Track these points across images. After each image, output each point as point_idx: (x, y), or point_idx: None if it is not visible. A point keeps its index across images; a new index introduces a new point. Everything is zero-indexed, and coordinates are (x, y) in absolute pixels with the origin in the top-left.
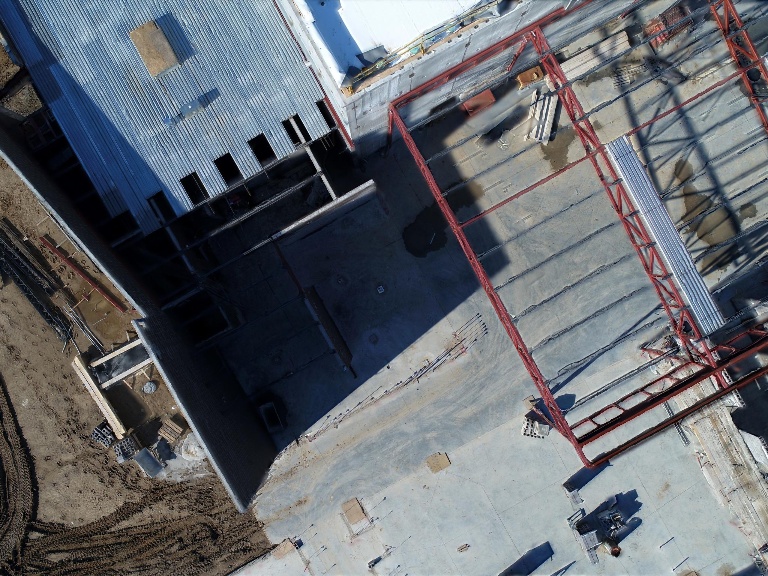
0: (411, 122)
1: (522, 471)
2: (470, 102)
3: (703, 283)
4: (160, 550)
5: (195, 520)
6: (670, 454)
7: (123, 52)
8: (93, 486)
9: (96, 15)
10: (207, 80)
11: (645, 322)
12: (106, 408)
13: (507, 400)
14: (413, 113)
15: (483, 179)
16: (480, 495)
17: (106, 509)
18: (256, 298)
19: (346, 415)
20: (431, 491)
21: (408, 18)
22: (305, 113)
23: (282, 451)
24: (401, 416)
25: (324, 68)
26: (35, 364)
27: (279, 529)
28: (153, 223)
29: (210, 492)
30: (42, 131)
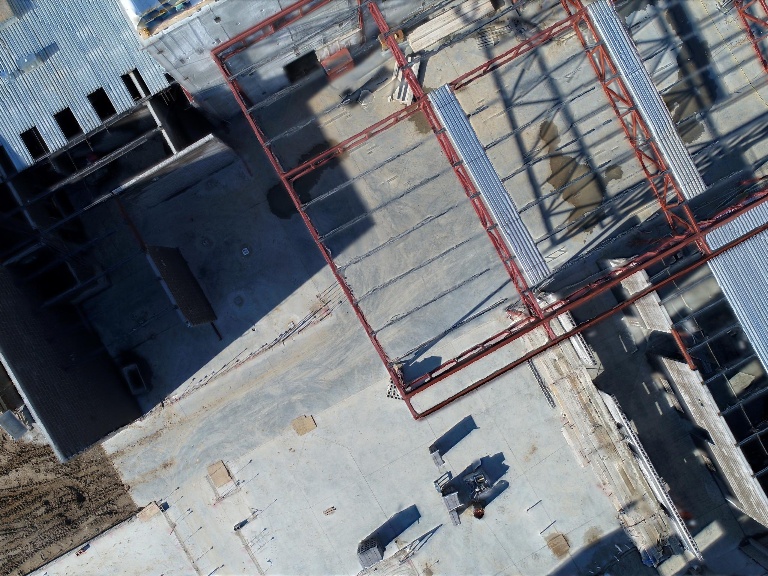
0: (265, 81)
1: (388, 434)
2: (327, 61)
3: (528, 233)
4: (27, 513)
5: (62, 483)
6: (537, 417)
7: None
8: None
9: None
10: (46, 34)
11: (510, 284)
12: None
13: (373, 362)
14: (259, 69)
15: None
16: (346, 458)
17: None
18: (120, 260)
19: (212, 377)
20: (297, 454)
21: None
22: (144, 67)
23: (147, 413)
24: (267, 378)
25: None
26: None
27: (145, 492)
28: None
29: None
30: None
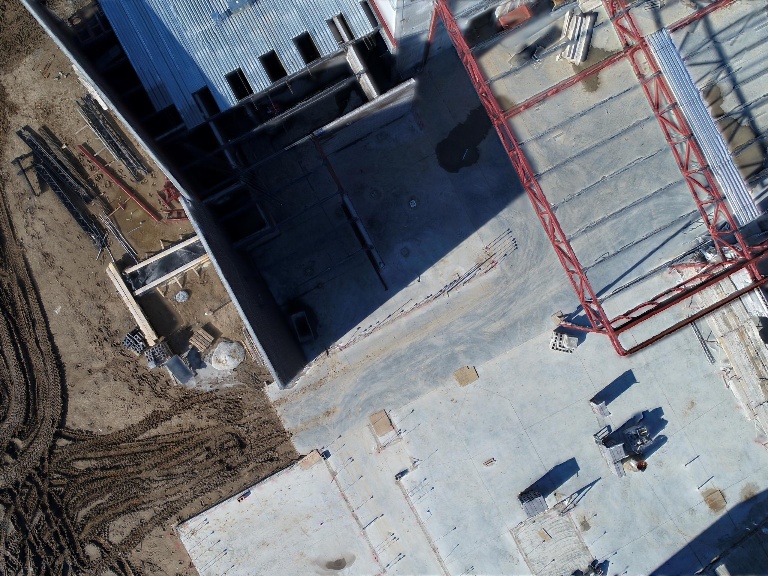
0: None
1: (549, 386)
2: (505, 18)
3: (738, 175)
4: (188, 459)
5: (223, 430)
6: (696, 372)
7: None
8: (123, 394)
9: None
10: None
11: (673, 241)
12: (139, 314)
13: (536, 315)
14: None
15: (515, 97)
16: (507, 409)
17: (135, 417)
18: (290, 209)
19: (376, 327)
20: (459, 405)
21: None
22: (349, 12)
23: (312, 361)
24: (431, 329)
25: None
26: (69, 271)
27: (307, 440)
28: (197, 117)
29: (239, 402)
30: (91, 26)
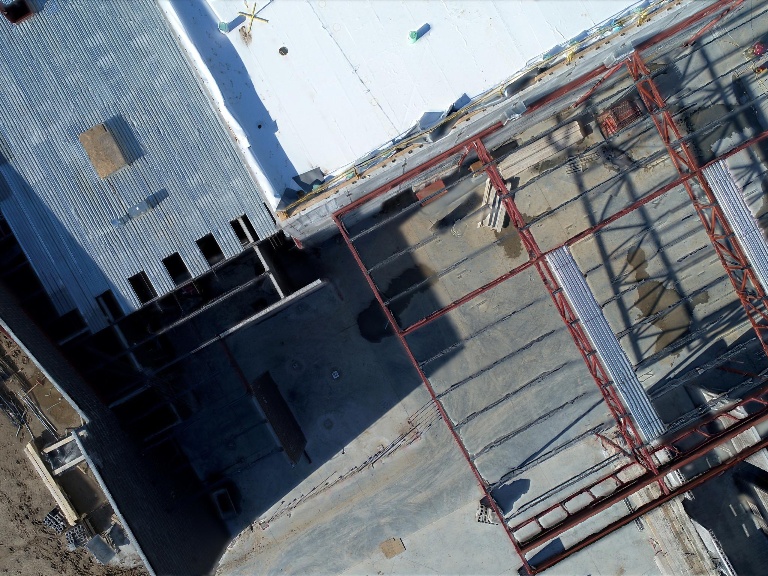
0: (363, 214)
1: (477, 557)
2: (422, 193)
3: (643, 391)
4: None
5: None
6: (625, 539)
7: (72, 152)
8: (45, 572)
9: (46, 116)
10: (156, 180)
11: (599, 407)
12: (59, 495)
13: (462, 485)
14: (362, 210)
15: (437, 265)
16: None
17: None
18: (211, 383)
19: (301, 500)
20: None
21: (344, 141)
22: (253, 213)
23: (236, 537)
24: (356, 501)
25: None
26: None
27: None
28: (101, 321)
29: None
30: None
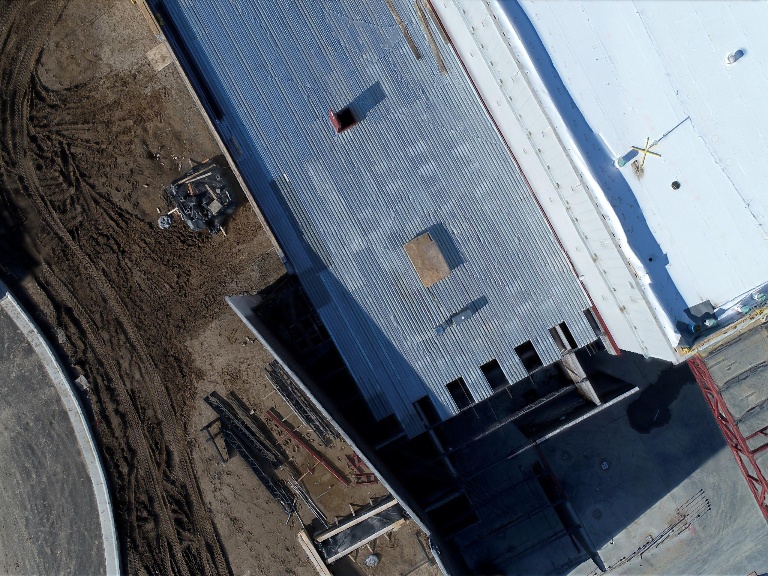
0: None
1: None
2: None
3: None
4: None
5: None
6: None
7: (392, 259)
8: None
9: (366, 223)
10: (475, 288)
11: None
12: None
13: None
14: None
15: None
16: None
17: None
18: (481, 473)
19: None
20: None
21: (734, 274)
22: (572, 321)
23: None
24: None
25: (658, 327)
26: (258, 536)
27: None
28: (418, 426)
29: None
30: (309, 335)
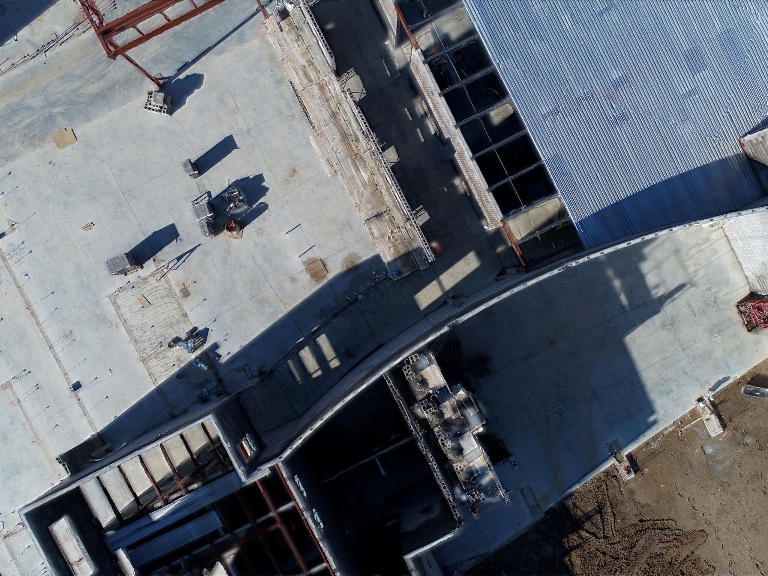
0: None
1: (149, 151)
2: None
3: None
4: None
5: None
6: (298, 139)
7: None
8: None
9: None
10: None
11: None
12: None
13: (135, 78)
14: None
15: None
16: (106, 173)
17: None
18: None
19: None
20: (57, 167)
21: None
22: None
23: None
24: (28, 90)
25: None
26: None
27: None
28: None
29: None
30: None
